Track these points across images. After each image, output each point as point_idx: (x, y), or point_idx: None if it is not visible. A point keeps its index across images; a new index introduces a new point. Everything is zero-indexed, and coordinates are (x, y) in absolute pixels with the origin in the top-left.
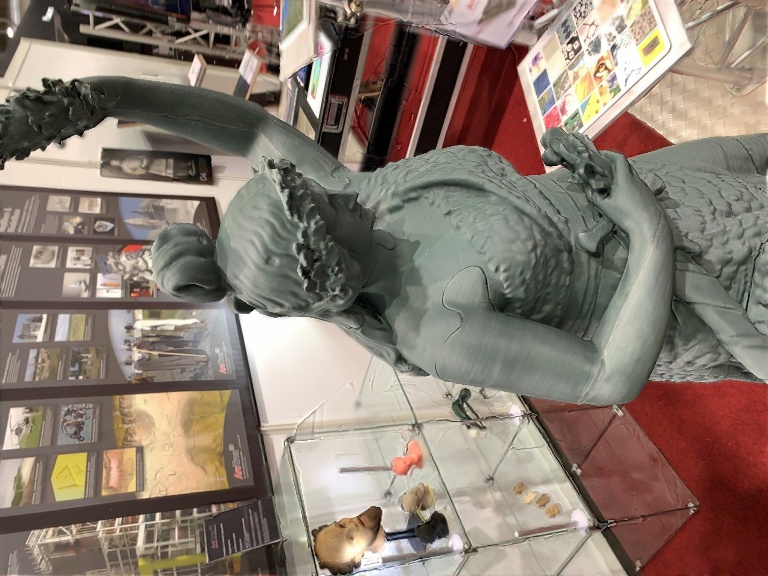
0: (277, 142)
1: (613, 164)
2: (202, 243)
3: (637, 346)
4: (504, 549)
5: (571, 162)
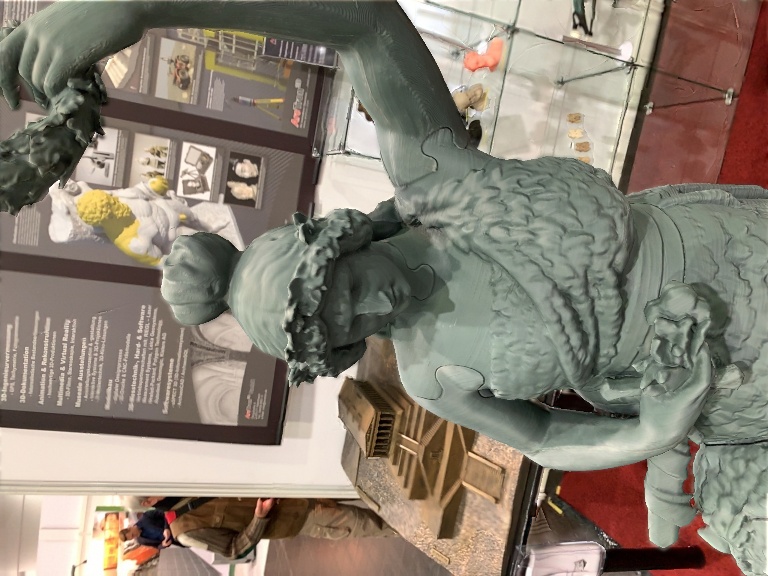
0: (372, 73)
1: (692, 379)
2: (213, 292)
3: (567, 468)
4: (530, 145)
5: (652, 356)
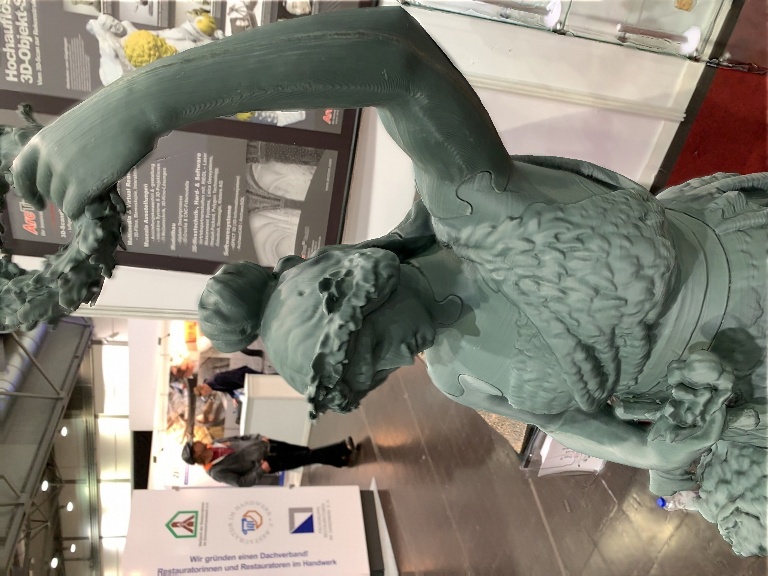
0: (404, 130)
1: (701, 433)
2: (246, 333)
3: None
4: None
5: None
